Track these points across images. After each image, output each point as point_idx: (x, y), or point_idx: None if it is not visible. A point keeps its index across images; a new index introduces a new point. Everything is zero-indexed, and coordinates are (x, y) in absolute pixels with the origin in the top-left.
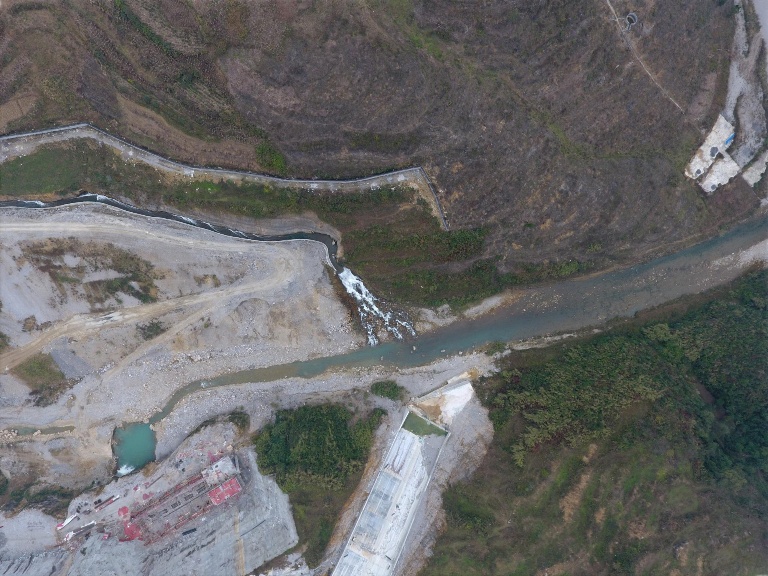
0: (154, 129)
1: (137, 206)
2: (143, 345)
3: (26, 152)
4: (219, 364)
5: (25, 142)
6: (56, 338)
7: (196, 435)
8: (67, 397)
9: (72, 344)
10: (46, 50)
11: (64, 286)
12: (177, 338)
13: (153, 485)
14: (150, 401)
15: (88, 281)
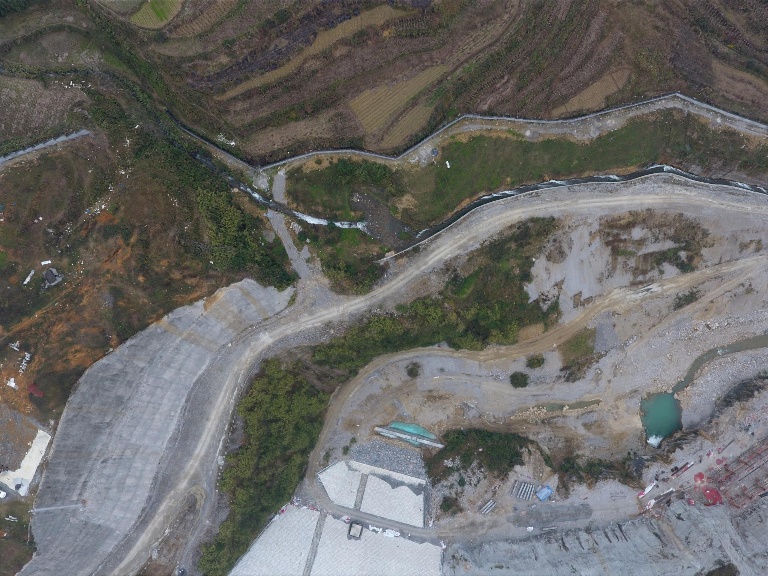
0: (748, 94)
1: (701, 174)
2: (670, 315)
3: (617, 126)
4: (738, 330)
5: (616, 116)
6: (599, 313)
7: (755, 399)
8: (594, 371)
9: (616, 317)
10: (639, 22)
11: (618, 260)
12: (711, 306)
13: (725, 450)
14: (674, 371)
15: (643, 253)
